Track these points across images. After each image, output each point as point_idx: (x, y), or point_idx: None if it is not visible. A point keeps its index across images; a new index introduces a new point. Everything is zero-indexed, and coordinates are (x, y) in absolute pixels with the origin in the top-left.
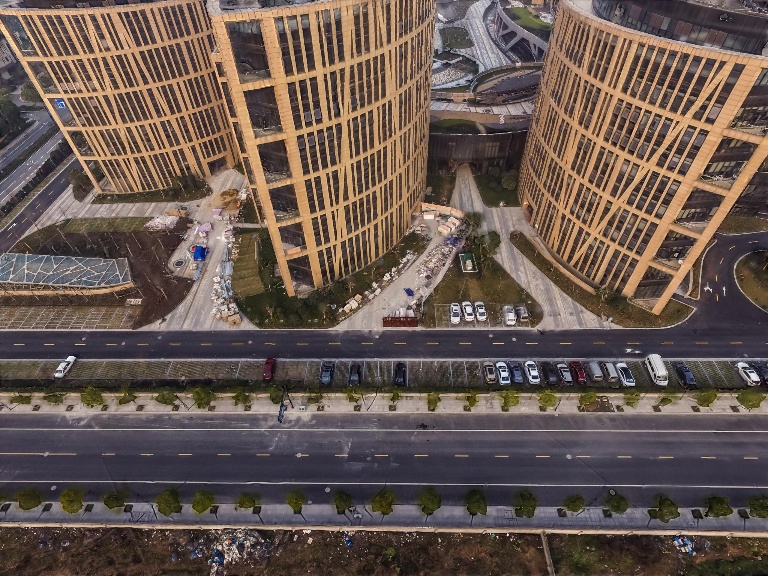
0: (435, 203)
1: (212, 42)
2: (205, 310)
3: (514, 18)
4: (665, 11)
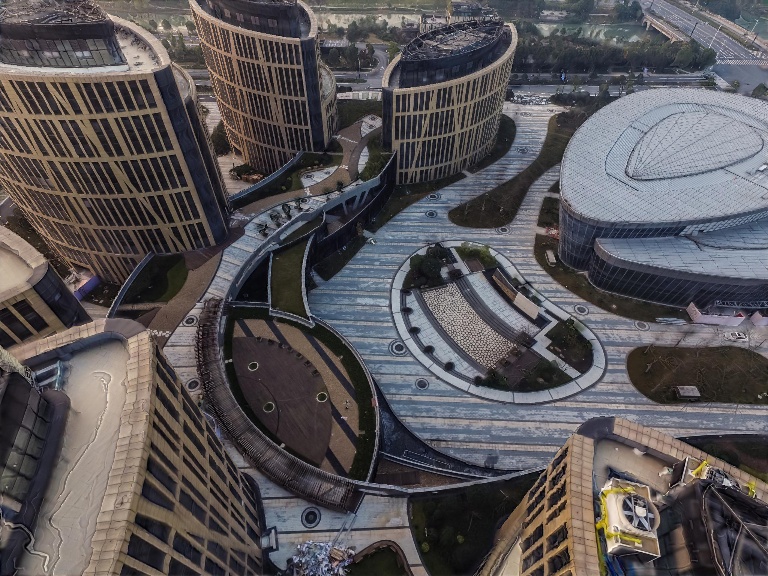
0: (105, 293)
1: (229, 63)
2: None
3: None
4: None
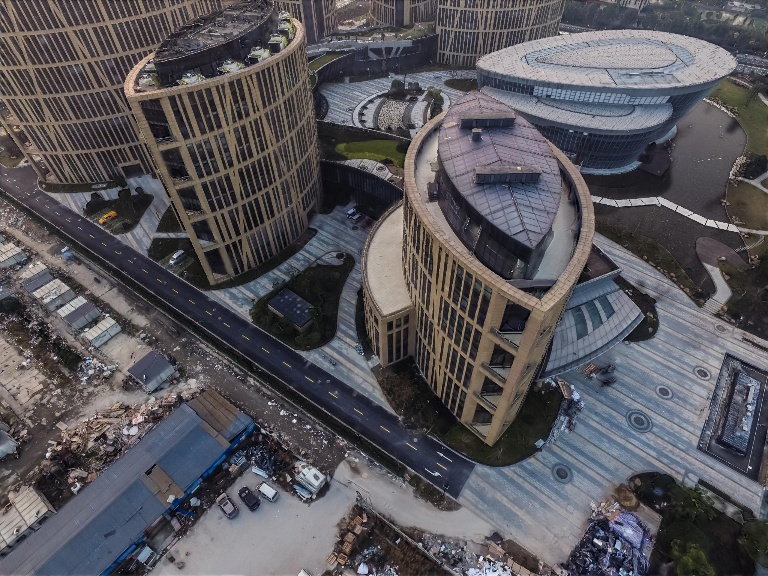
0: None
1: None
2: None
3: None
4: None
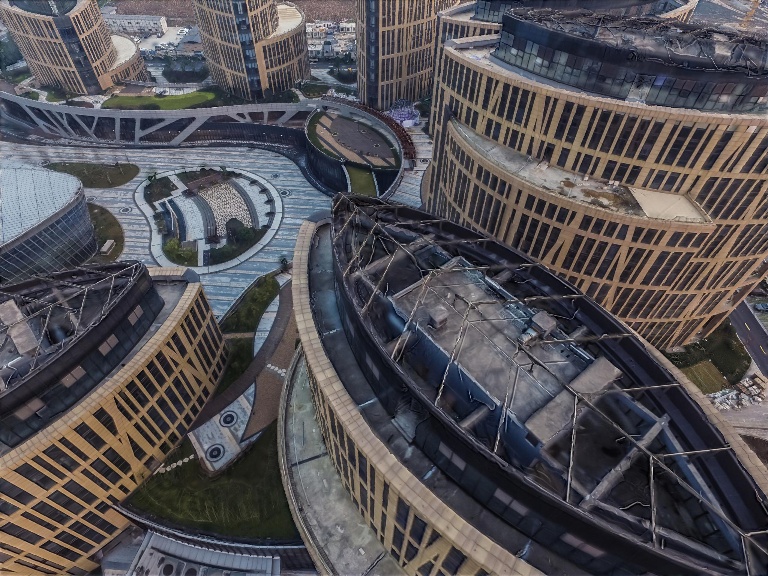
0: None
1: None
2: (761, 412)
3: (155, 108)
4: (623, 5)
